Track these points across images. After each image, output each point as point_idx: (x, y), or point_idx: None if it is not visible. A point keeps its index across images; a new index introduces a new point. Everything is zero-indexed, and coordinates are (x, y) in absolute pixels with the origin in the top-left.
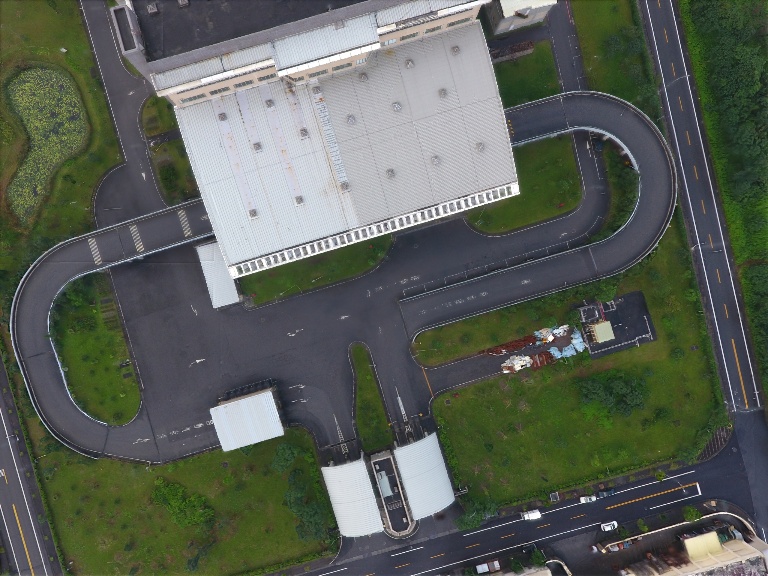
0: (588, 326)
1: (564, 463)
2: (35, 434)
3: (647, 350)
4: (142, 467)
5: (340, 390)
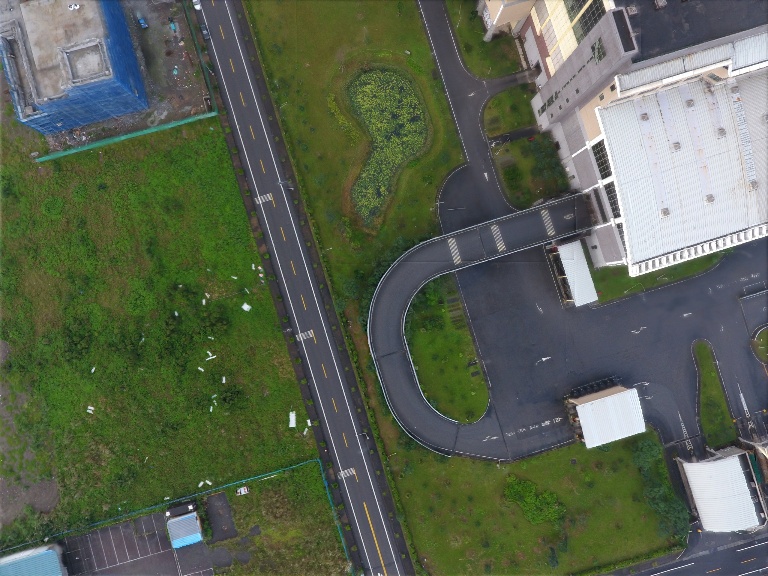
0: None
1: None
2: (385, 432)
3: None
4: (492, 464)
5: (684, 387)
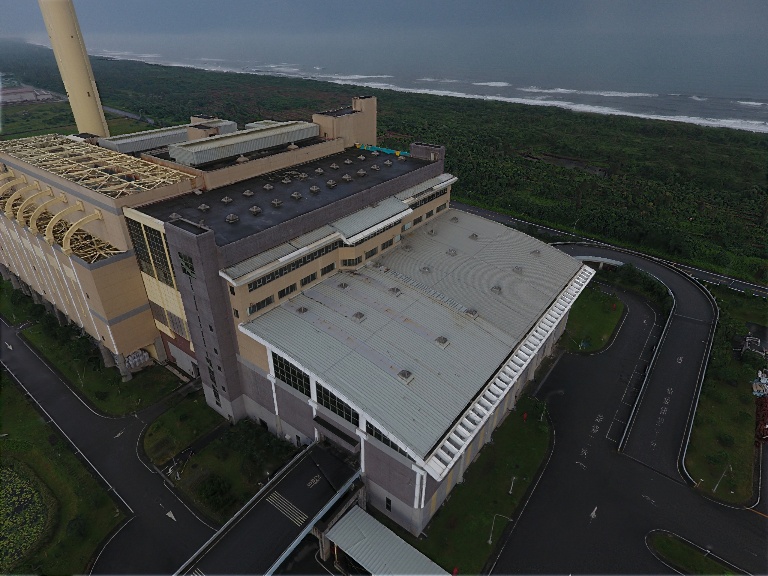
0: None
1: None
2: None
3: None
4: None
5: None
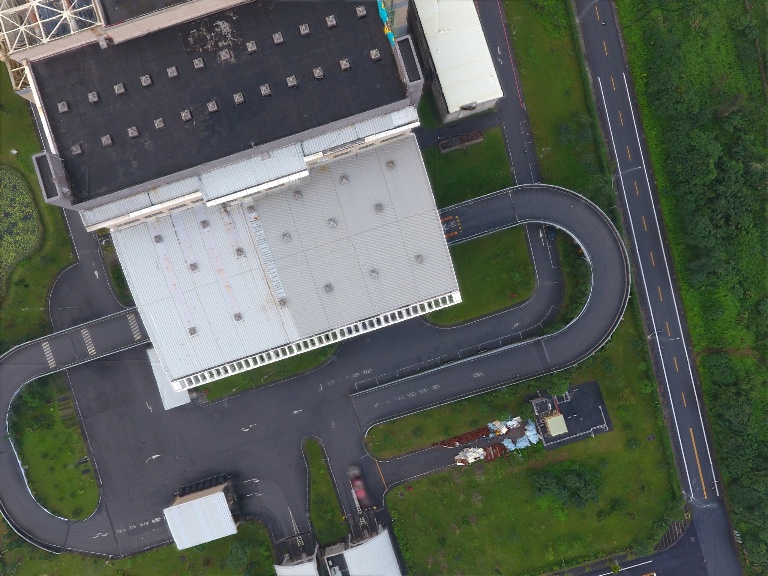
0: (542, 418)
1: (519, 554)
2: None
3: (603, 441)
4: (102, 561)
5: (294, 484)
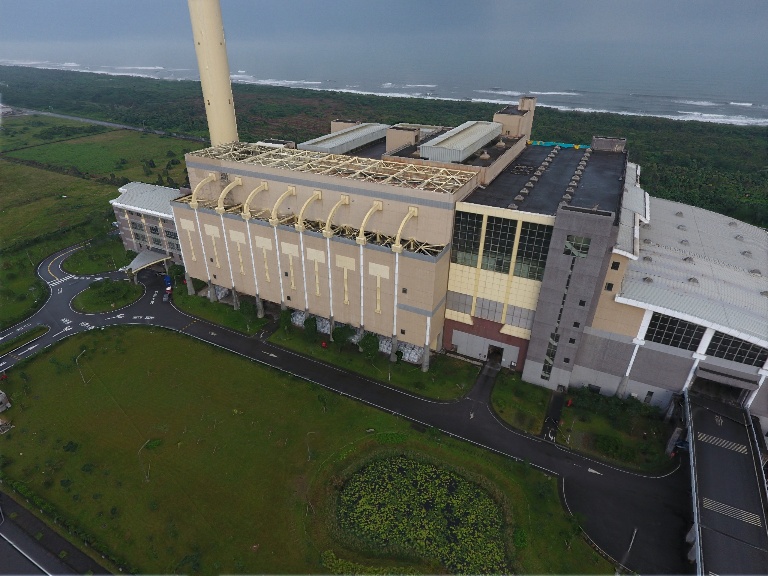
0: None
1: None
2: None
3: None
4: None
5: None
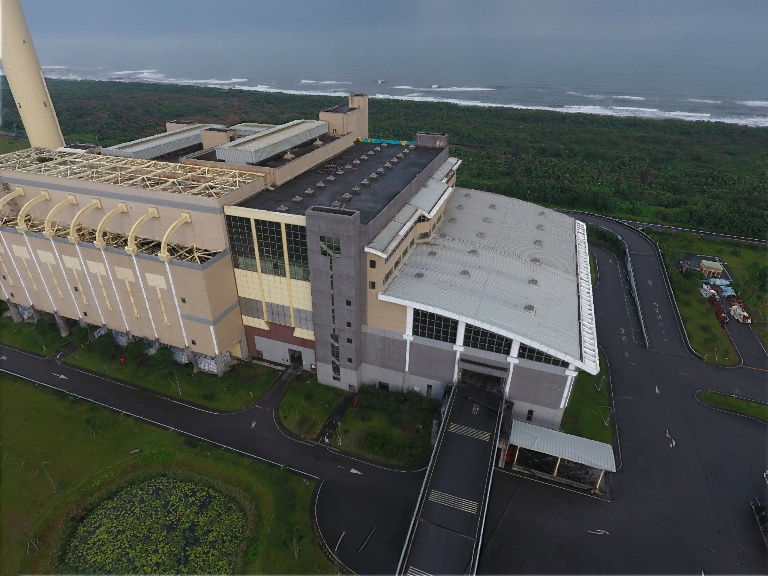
0: None
1: None
2: None
3: None
4: None
5: None
